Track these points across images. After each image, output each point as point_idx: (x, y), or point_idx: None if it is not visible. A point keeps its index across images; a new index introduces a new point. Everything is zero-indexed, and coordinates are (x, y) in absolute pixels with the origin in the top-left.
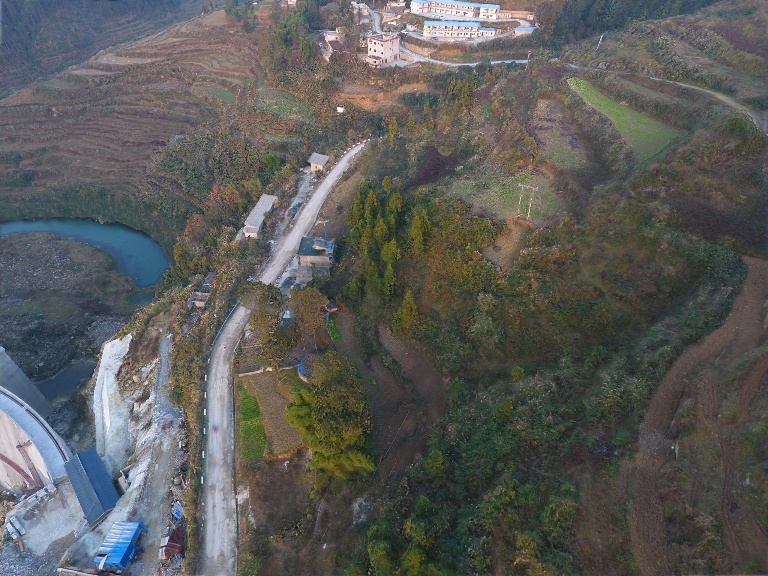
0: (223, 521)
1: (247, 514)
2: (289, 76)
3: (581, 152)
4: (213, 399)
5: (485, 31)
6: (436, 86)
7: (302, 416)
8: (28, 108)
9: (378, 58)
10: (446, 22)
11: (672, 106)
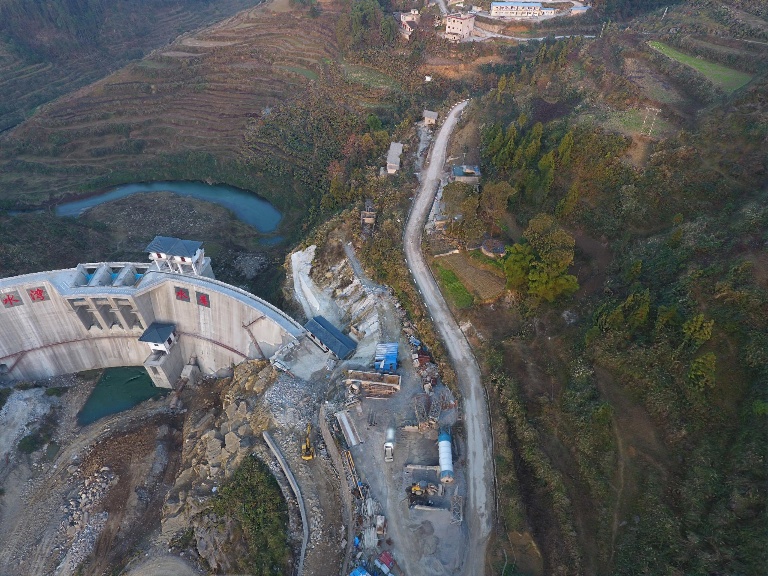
0: (457, 341)
1: (475, 334)
2: (369, 53)
3: (674, 92)
4: (417, 274)
5: (546, 10)
6: (509, 58)
7: (518, 261)
8: (130, 86)
9: (458, 34)
10: (512, 3)
11: (743, 56)
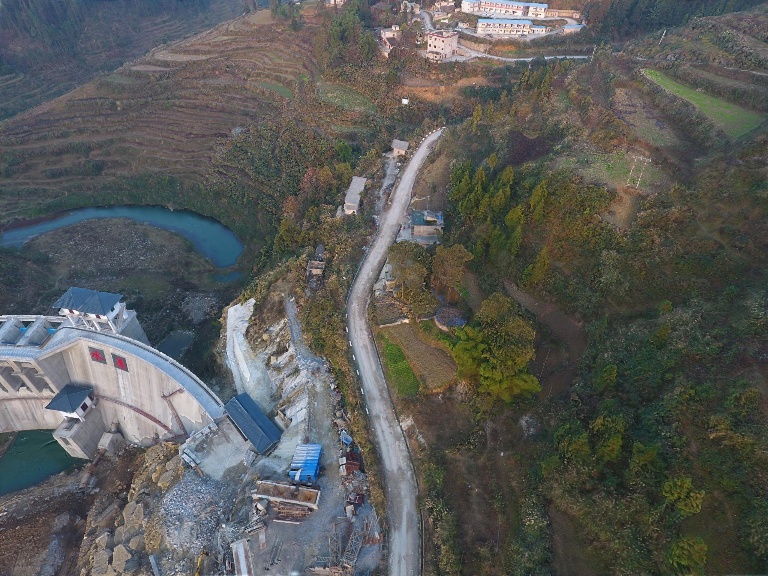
0: (394, 443)
1: (416, 436)
2: (347, 71)
3: (669, 132)
4: (358, 347)
5: (536, 28)
6: (494, 80)
7: (469, 349)
8: (94, 102)
9: (439, 53)
10: (499, 20)
11: (750, 91)
